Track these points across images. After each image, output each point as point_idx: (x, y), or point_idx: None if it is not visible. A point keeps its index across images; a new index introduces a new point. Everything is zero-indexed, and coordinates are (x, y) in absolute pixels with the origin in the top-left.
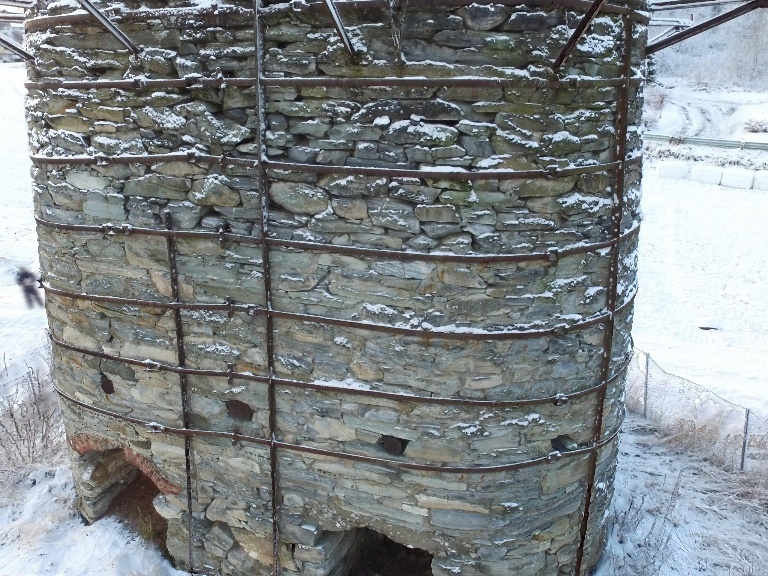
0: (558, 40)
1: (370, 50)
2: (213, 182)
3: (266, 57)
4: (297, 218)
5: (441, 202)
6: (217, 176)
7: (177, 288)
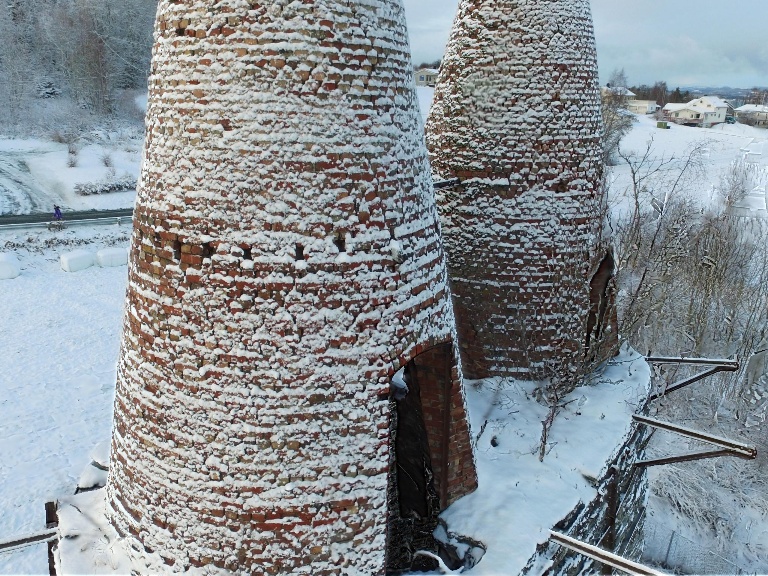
0: None
1: None
2: None
3: None
4: None
5: (644, 517)
6: None
7: None
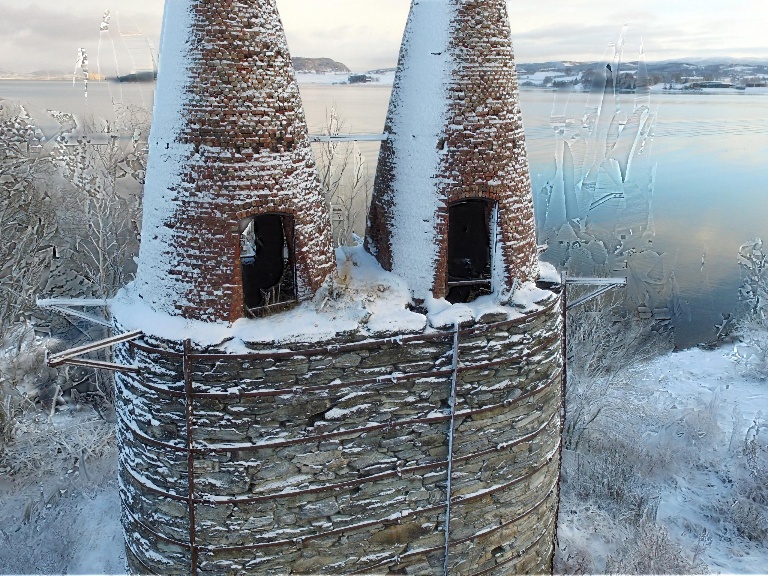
0: None
1: None
2: None
3: None
4: None
5: None
6: None
7: None
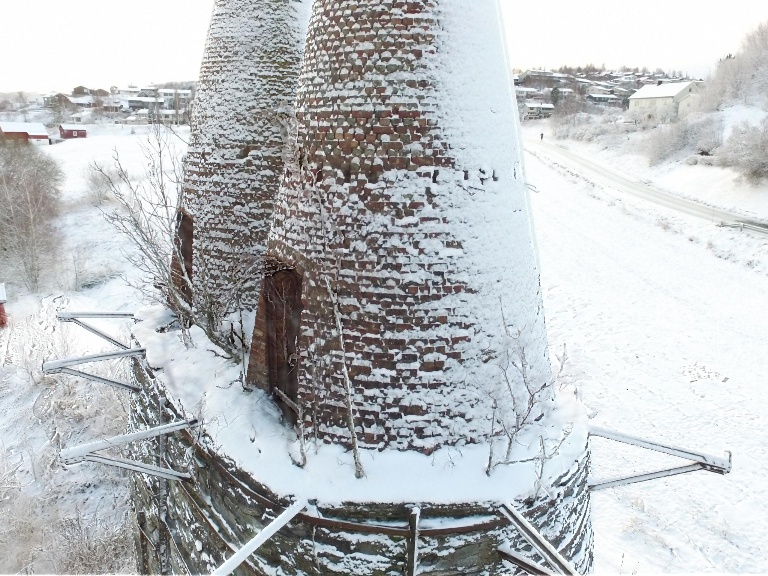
0: (303, 554)
1: (199, 480)
2: (153, 510)
3: (168, 442)
4: (177, 575)
5: None
6: (156, 507)
7: (148, 567)
